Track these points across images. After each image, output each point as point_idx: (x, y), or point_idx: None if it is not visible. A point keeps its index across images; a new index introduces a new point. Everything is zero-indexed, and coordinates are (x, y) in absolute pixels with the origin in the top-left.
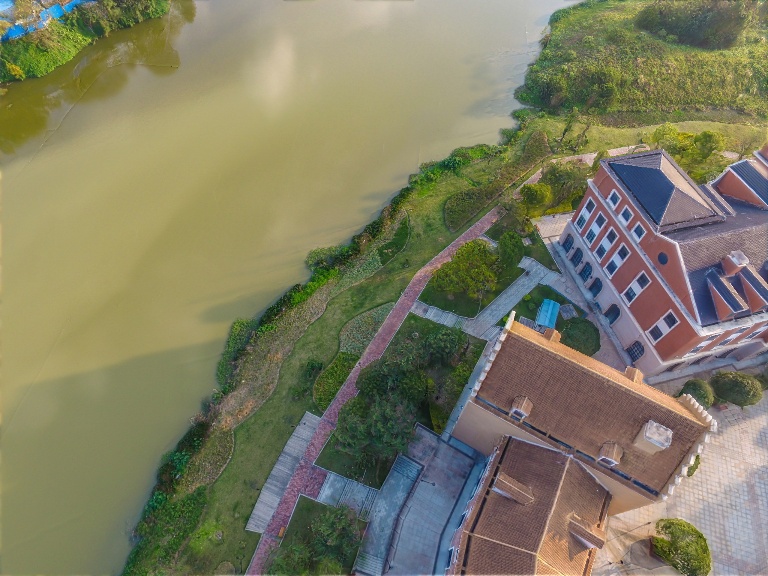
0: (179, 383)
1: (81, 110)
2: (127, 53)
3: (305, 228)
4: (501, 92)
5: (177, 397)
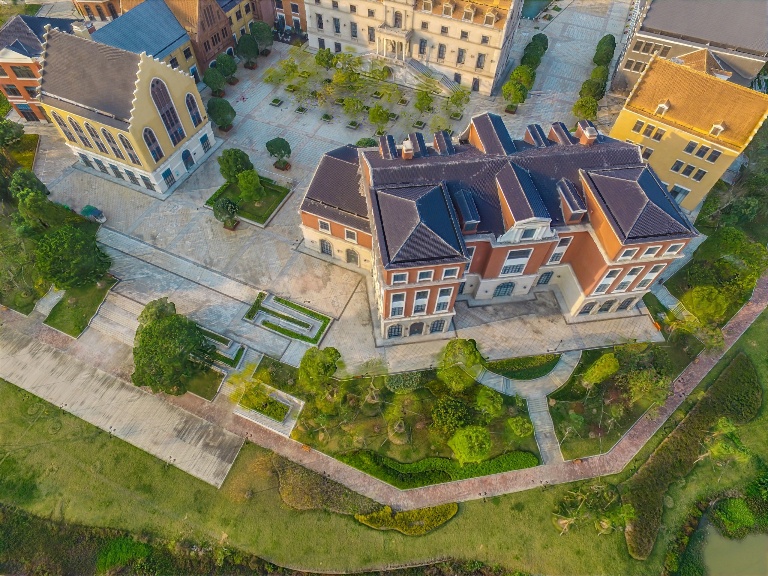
0: None
1: None
2: None
3: None
4: None
5: None
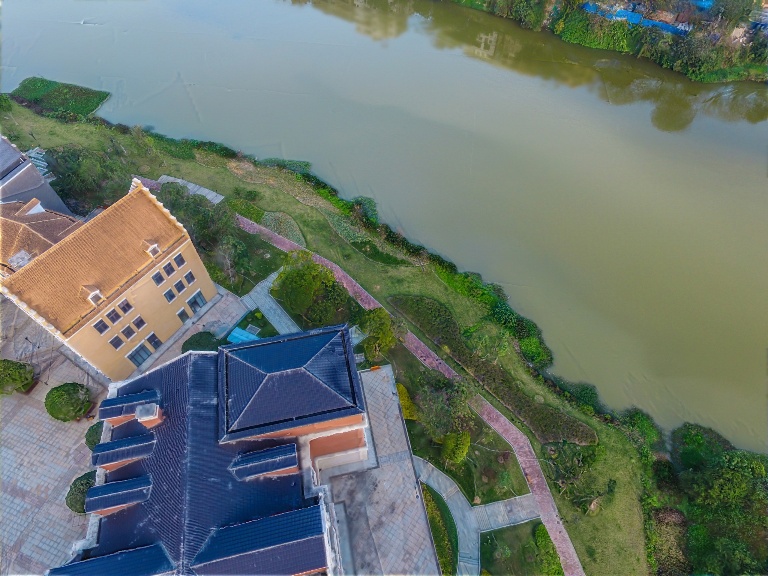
0: (268, 145)
1: (526, 64)
2: (651, 86)
3: (400, 195)
4: (694, 404)
5: (259, 145)
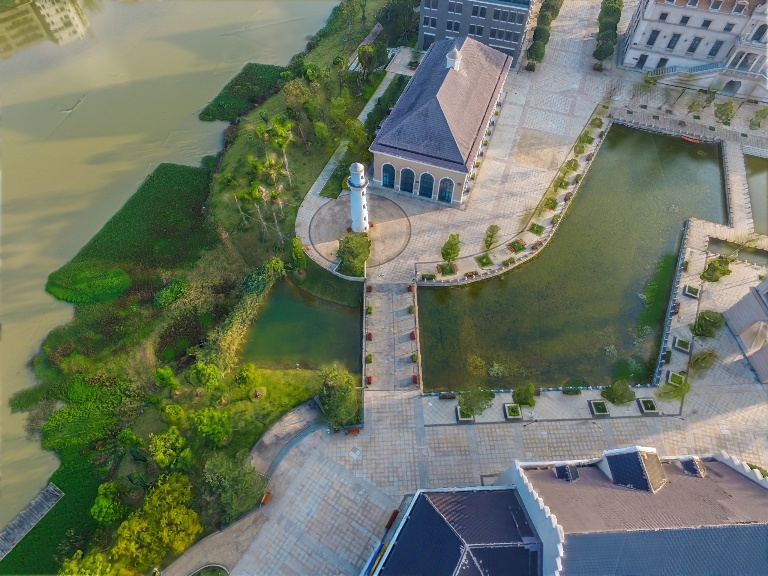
0: None
1: None
2: None
3: None
4: None
5: None
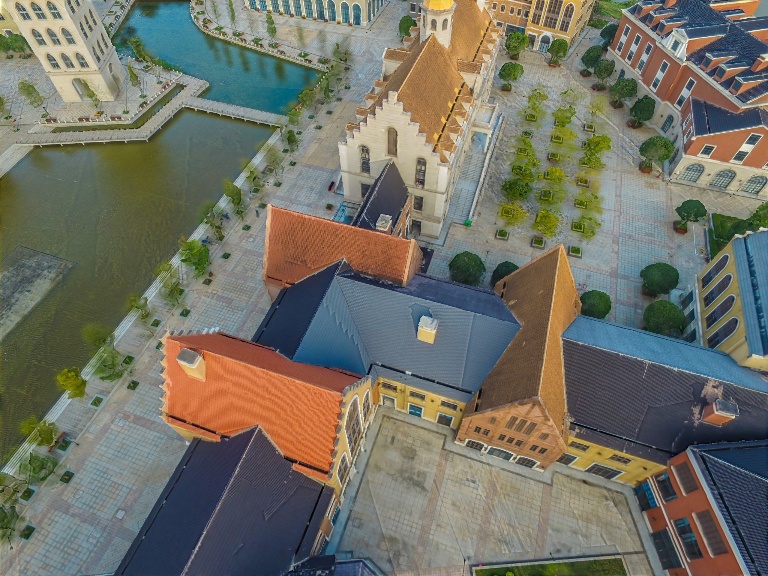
0: None
1: None
2: None
3: None
4: None
5: None
